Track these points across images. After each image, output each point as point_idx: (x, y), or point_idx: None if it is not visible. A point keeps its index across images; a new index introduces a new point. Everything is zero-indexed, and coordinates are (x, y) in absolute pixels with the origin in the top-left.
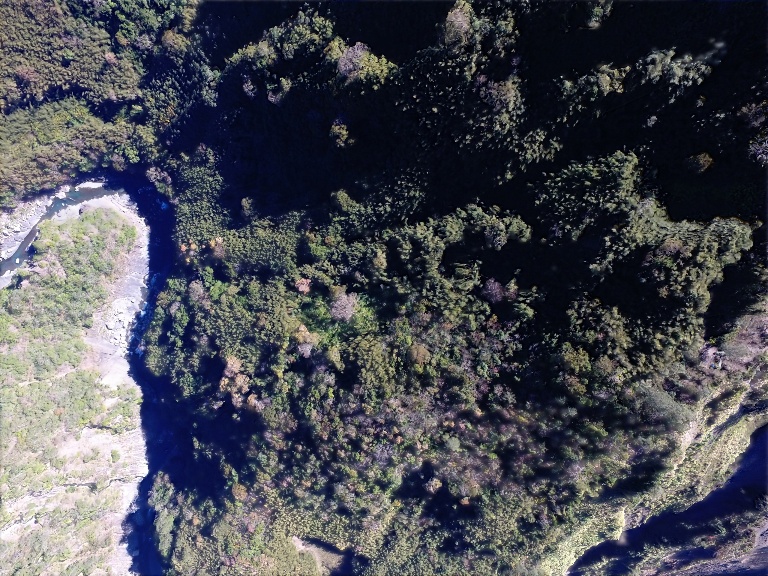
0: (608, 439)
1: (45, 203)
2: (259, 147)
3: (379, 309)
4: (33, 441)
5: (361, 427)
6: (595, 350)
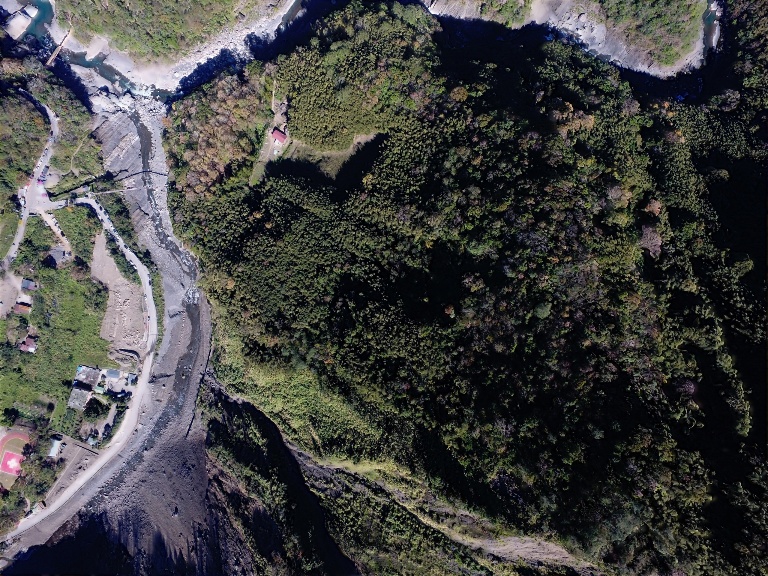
0: (552, 464)
1: None
2: None
3: None
4: None
5: (562, 226)
6: (673, 469)
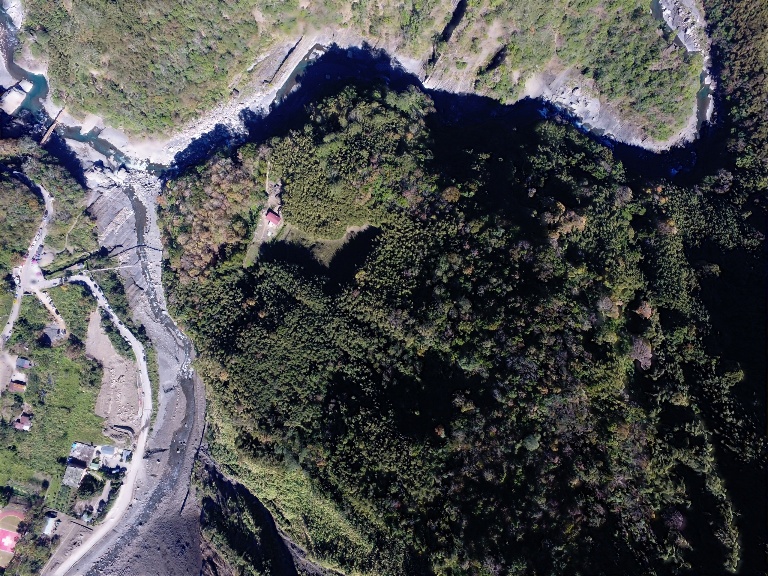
0: None
1: (705, 63)
2: (761, 294)
3: (627, 385)
4: (525, 2)
5: (552, 351)
6: None
